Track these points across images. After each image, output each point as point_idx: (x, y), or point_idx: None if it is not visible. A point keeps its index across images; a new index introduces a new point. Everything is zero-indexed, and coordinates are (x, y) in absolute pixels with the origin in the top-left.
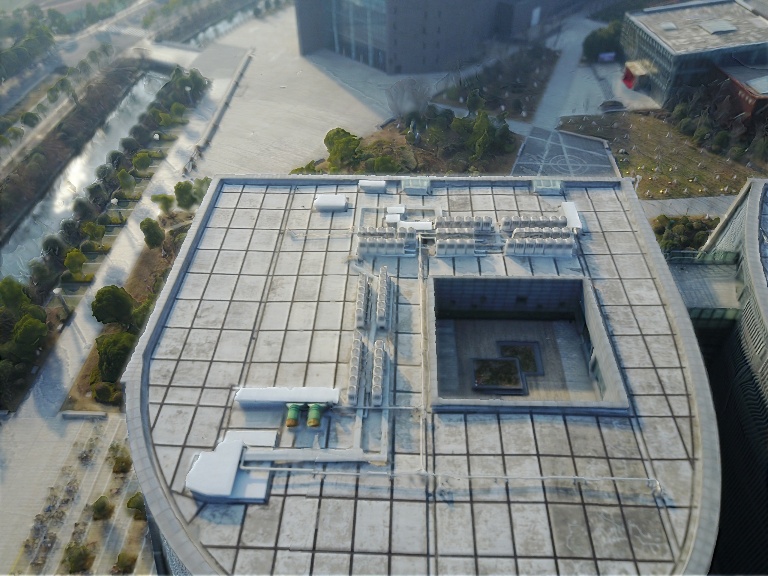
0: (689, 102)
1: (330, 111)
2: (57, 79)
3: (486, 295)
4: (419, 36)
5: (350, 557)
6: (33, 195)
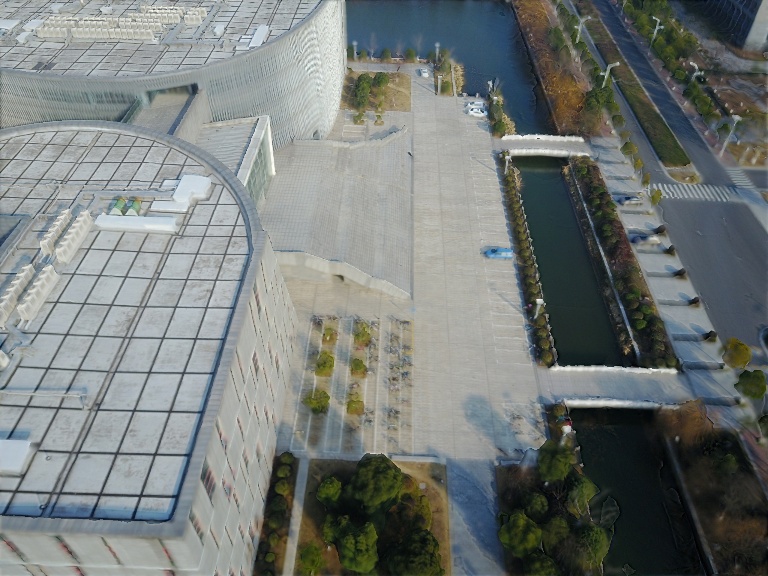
0: None
1: None
2: None
3: None
4: None
5: None
6: None
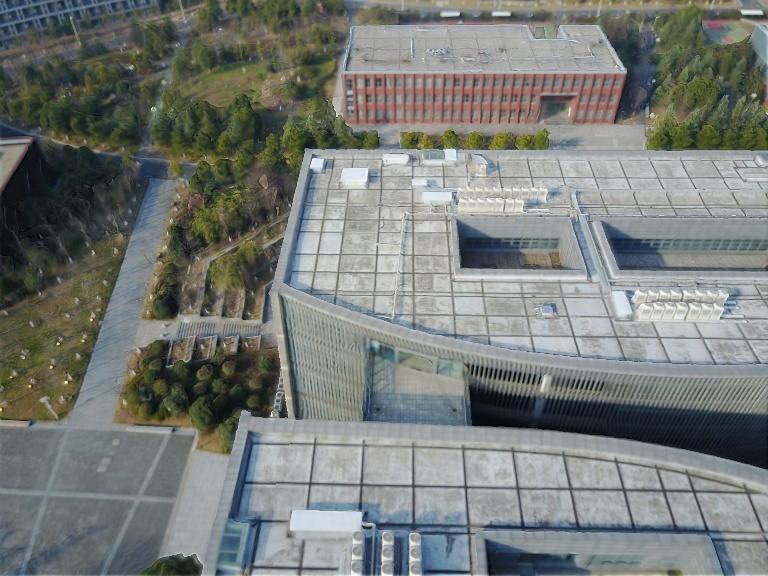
0: None
1: None
2: None
3: None
4: None
5: None
6: None
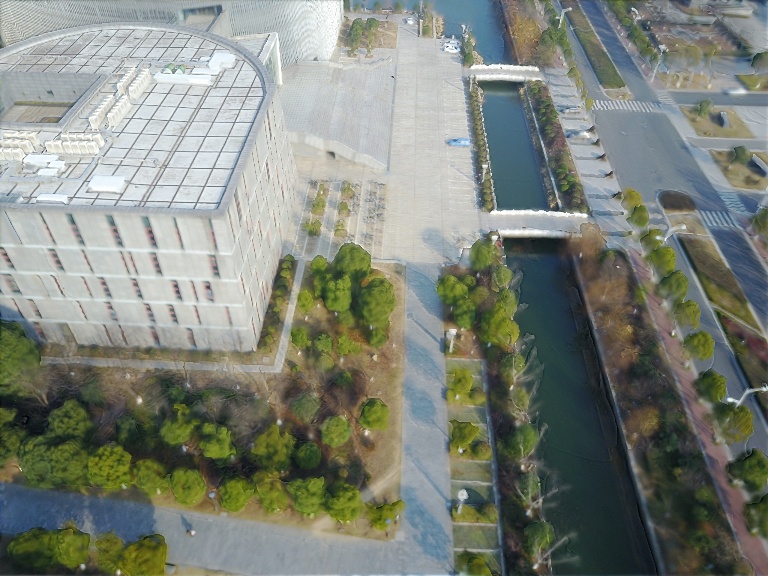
0: None
1: None
2: None
3: None
4: None
5: None
6: None
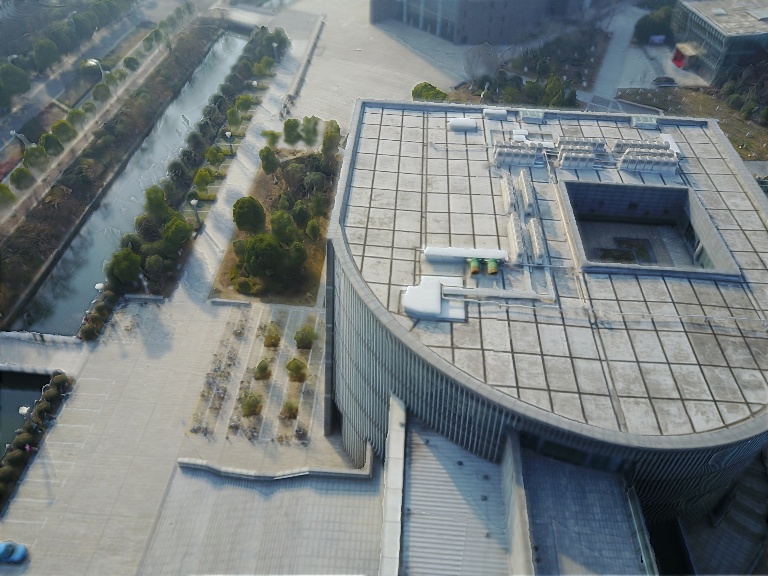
0: (738, 79)
1: (405, 72)
2: (144, 32)
3: (604, 200)
4: (487, 9)
5: (541, 357)
6: (143, 129)
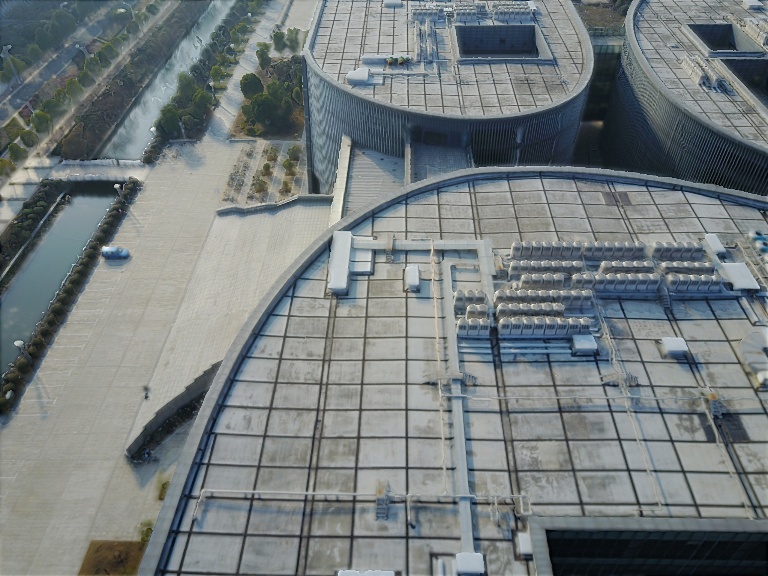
0: None
1: None
2: None
3: (483, 38)
4: None
5: (424, 95)
6: (166, 53)
